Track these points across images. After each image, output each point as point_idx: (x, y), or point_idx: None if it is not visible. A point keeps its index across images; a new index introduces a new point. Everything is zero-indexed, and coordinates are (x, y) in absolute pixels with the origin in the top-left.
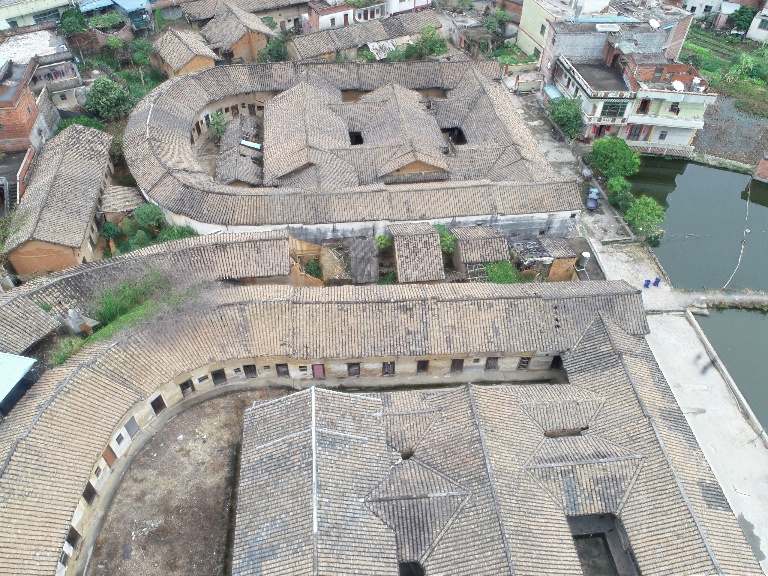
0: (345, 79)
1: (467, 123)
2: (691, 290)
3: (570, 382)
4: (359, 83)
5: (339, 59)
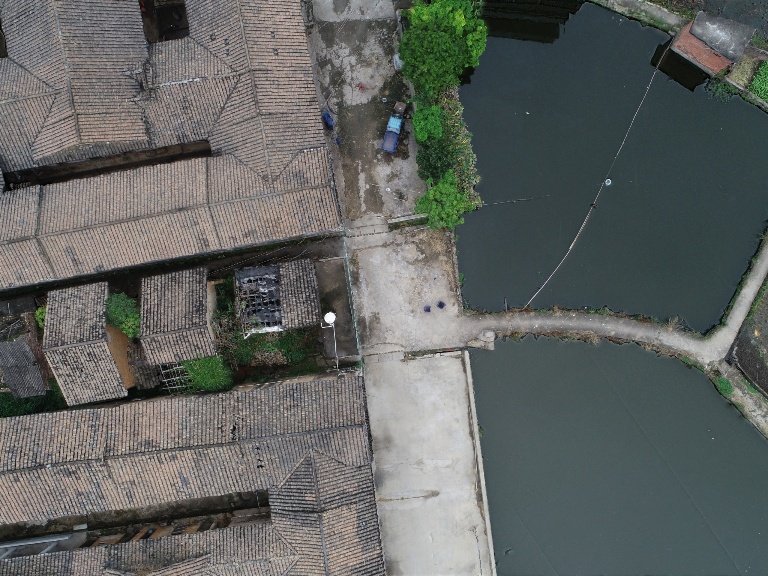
0: None
1: None
2: (484, 312)
3: (272, 523)
4: None
5: None
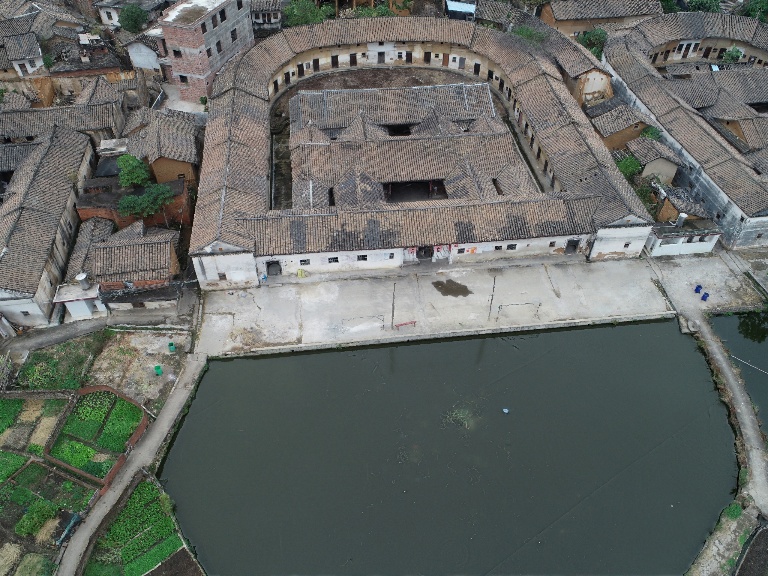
0: None
1: None
2: (711, 325)
3: None
4: None
5: None
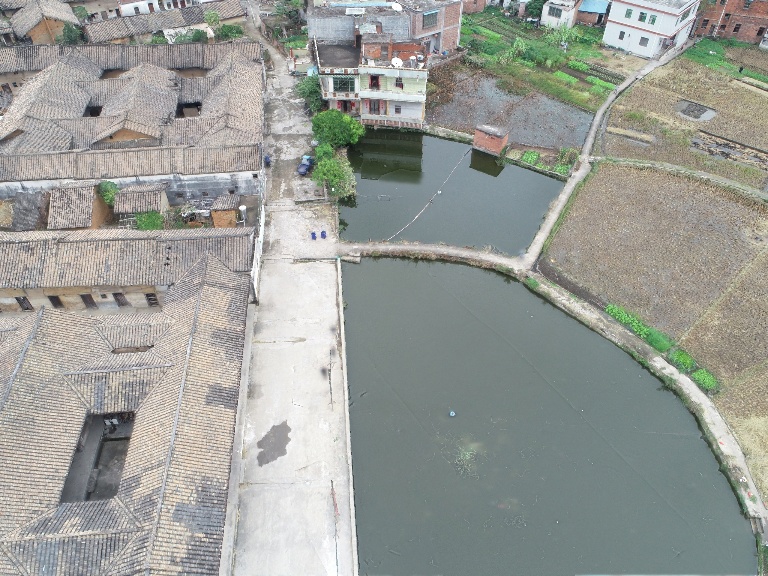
0: (108, 60)
1: (207, 98)
2: (354, 242)
3: (162, 310)
4: (122, 63)
5: (132, 44)
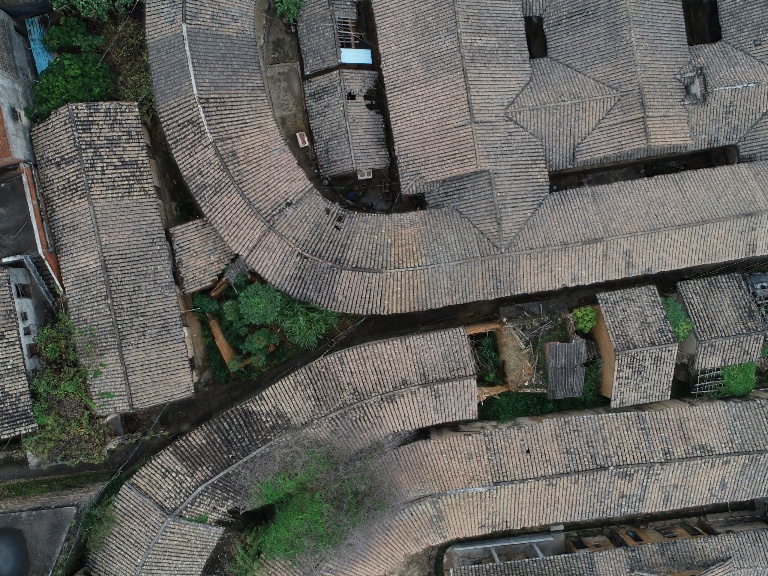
0: None
1: None
2: None
3: None
4: None
5: None
